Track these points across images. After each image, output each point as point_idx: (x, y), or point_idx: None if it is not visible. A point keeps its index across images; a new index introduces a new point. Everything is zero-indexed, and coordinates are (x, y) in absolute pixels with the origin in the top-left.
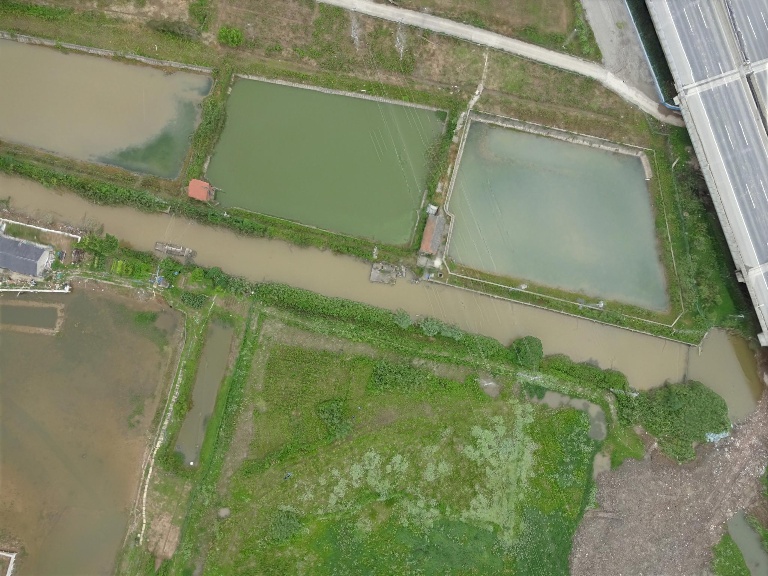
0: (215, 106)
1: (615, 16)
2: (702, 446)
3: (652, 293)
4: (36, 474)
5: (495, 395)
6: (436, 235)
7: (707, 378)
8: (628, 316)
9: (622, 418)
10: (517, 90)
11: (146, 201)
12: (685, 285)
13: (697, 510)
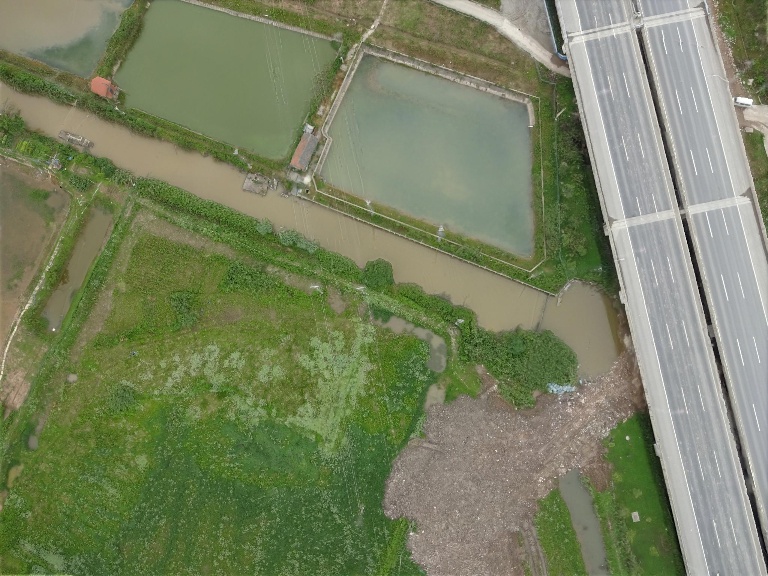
0: (130, 16)
1: None
2: (544, 396)
3: (518, 238)
4: None
5: (341, 311)
6: (306, 152)
7: (563, 330)
8: (487, 255)
9: (463, 353)
10: (411, 28)
11: (56, 92)
12: (549, 232)
13: (527, 459)
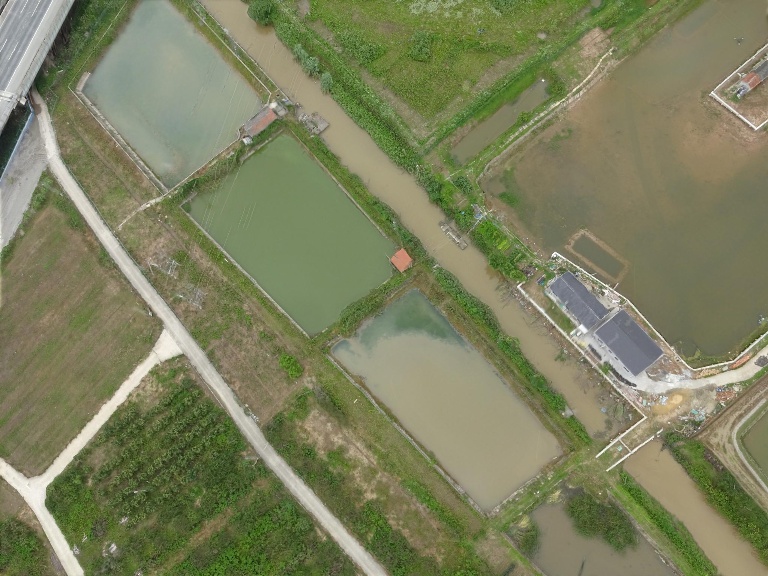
0: (344, 321)
1: (8, 195)
2: None
3: (152, 3)
4: (662, 141)
5: (305, 0)
6: (258, 119)
7: None
8: None
9: None
10: (120, 188)
11: (448, 281)
12: None
13: None
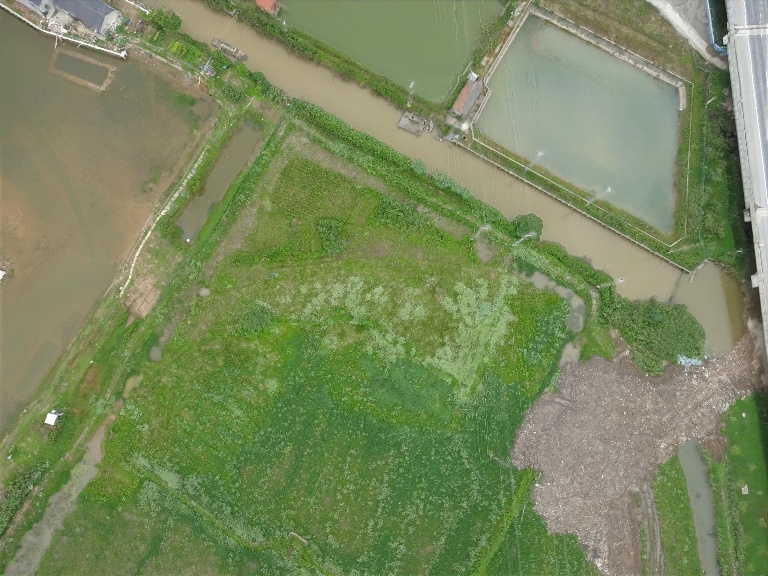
0: None
1: None
2: (672, 366)
3: (659, 213)
4: (45, 209)
5: (486, 260)
6: (470, 98)
7: (693, 307)
8: (631, 225)
9: (601, 316)
10: None
11: None
12: (692, 211)
13: (652, 424)
